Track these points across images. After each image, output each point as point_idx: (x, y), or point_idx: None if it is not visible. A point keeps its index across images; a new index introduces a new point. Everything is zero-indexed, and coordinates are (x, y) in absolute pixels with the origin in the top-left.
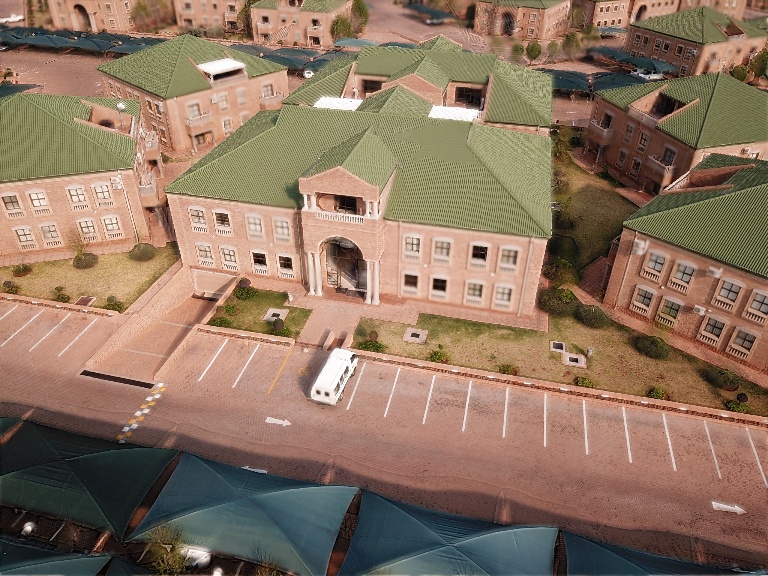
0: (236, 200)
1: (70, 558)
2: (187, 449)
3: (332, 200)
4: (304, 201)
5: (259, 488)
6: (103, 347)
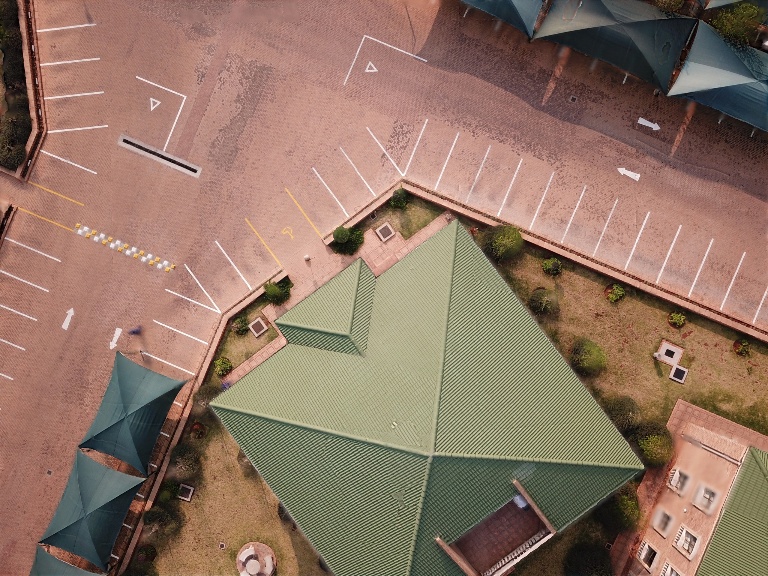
0: None
1: None
2: None
3: None
4: None
5: None
6: None
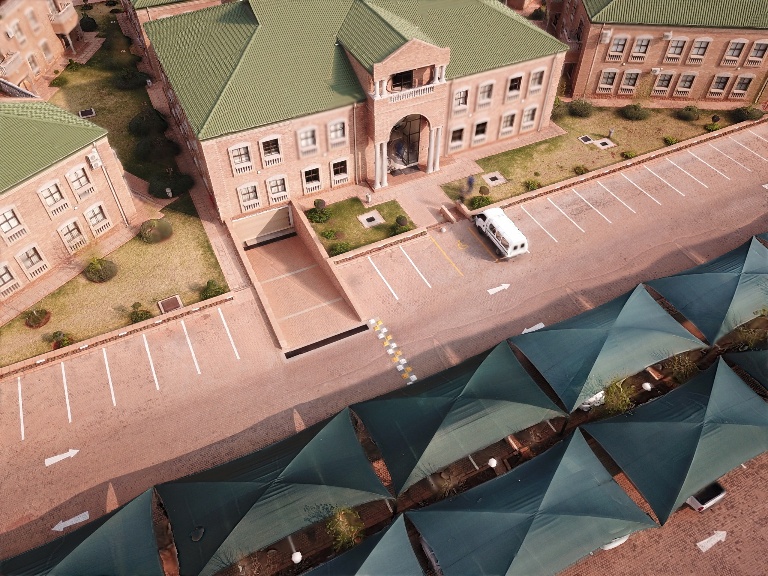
0: (289, 118)
1: (567, 445)
2: (468, 348)
3: (390, 80)
4: (376, 89)
5: (607, 318)
6: (275, 325)
